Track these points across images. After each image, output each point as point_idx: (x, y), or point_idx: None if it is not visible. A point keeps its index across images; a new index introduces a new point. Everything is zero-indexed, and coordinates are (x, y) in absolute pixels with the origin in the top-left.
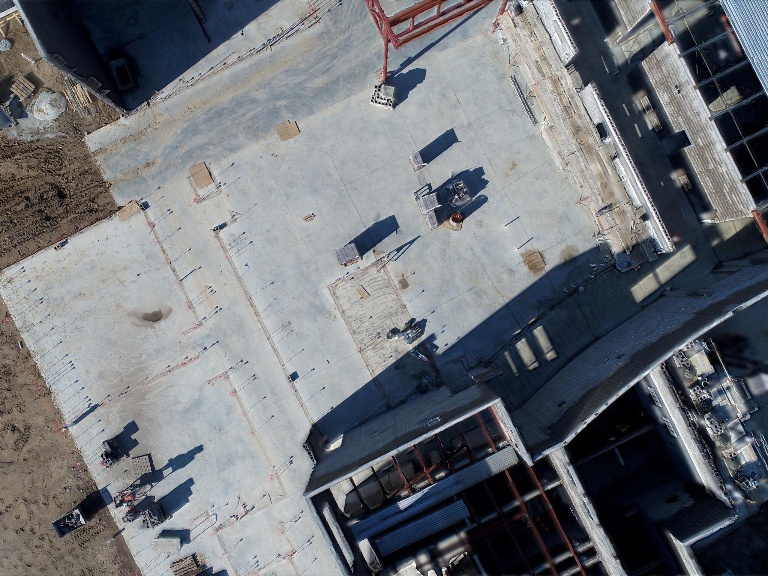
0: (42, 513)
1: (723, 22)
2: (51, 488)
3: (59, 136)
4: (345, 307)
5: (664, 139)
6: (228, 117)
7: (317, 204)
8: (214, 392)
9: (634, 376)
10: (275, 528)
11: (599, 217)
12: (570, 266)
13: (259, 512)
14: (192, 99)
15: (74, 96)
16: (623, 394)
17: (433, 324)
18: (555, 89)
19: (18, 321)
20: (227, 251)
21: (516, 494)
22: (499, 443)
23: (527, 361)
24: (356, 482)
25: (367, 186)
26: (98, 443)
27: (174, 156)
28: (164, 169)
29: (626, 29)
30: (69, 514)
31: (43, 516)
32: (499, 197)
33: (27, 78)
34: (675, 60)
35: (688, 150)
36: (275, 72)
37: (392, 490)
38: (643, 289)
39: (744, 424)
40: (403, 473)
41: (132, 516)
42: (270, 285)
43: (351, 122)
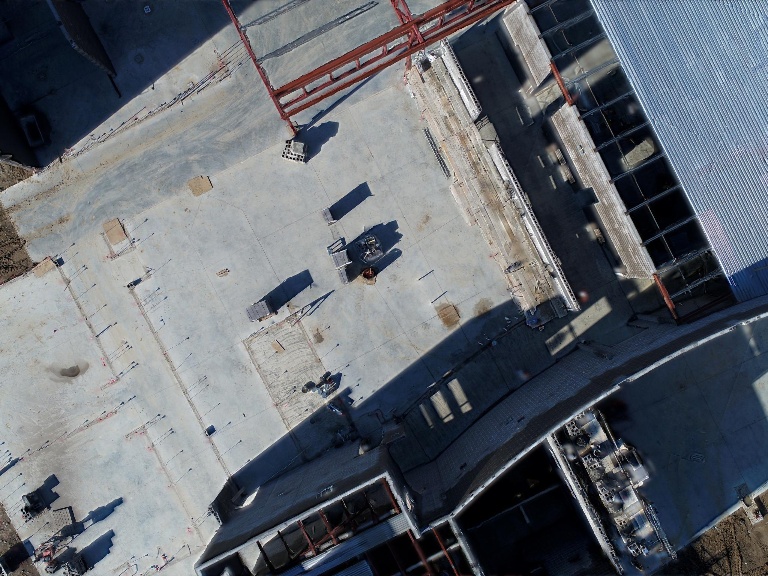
0: None
1: (624, 83)
2: None
3: None
4: (260, 361)
5: (579, 191)
6: (141, 173)
7: (231, 259)
8: (132, 446)
9: (521, 449)
10: None
11: (509, 274)
12: (484, 319)
13: (179, 562)
14: (104, 155)
15: None
16: (536, 446)
17: (348, 378)
18: (464, 145)
19: None
20: (142, 307)
21: (418, 554)
22: None
23: (442, 414)
24: (274, 533)
25: (281, 241)
26: (19, 496)
27: (87, 212)
28: (78, 225)
29: (535, 84)
30: None
31: None
32: (413, 251)
33: None
34: (576, 122)
35: (597, 206)
36: (187, 127)
37: (297, 550)
38: (558, 341)
39: (637, 491)
40: (307, 533)
41: (53, 568)
42: (185, 340)
43: (264, 177)
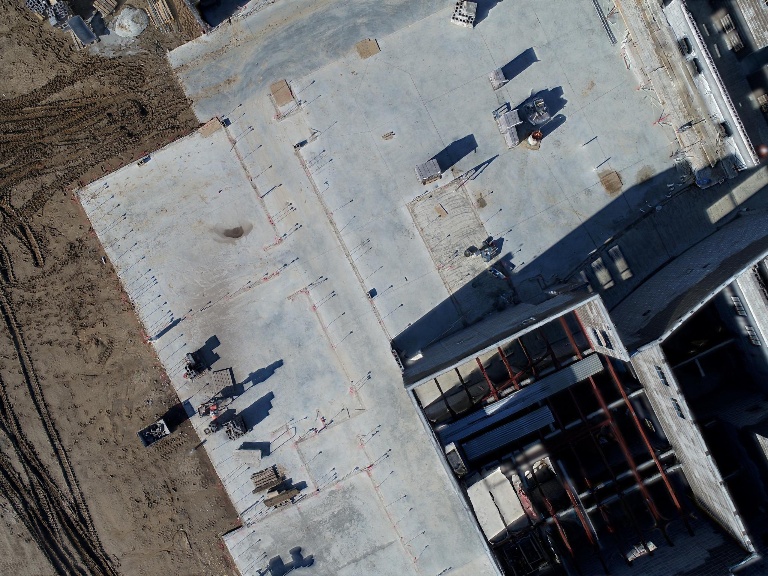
0: (125, 425)
1: None
2: (134, 401)
3: (141, 53)
4: (423, 225)
5: (743, 59)
6: (309, 35)
7: (396, 122)
8: (294, 308)
9: (730, 275)
10: (353, 441)
11: (680, 134)
12: (647, 186)
13: (337, 425)
14: (273, 16)
15: (156, 13)
16: (698, 313)
17: (510, 243)
18: (639, 5)
19: (102, 236)
20: (307, 169)
21: (600, 401)
22: (584, 351)
23: (602, 280)
24: (432, 397)
25: (446, 105)
26: (180, 357)
27: (255, 73)
28: (245, 86)
29: None
30: (153, 425)
31: (126, 428)
32: (577, 117)
33: None
34: None
35: None
36: None
37: (477, 396)
38: (719, 210)
39: None
40: None
41: (215, 427)
42: (349, 203)
43: (431, 40)
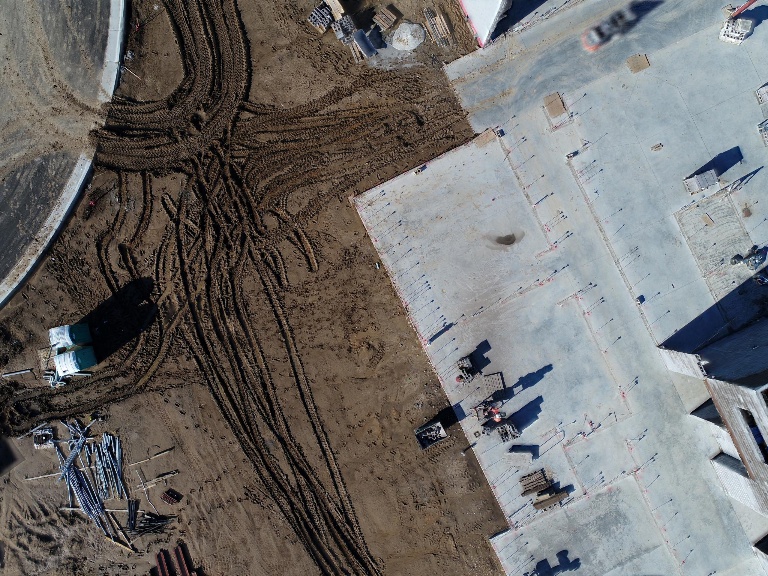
0: (394, 428)
1: None
2: (403, 404)
3: (417, 66)
4: (690, 234)
5: None
6: (581, 49)
7: (665, 134)
8: (564, 313)
9: None
10: (620, 445)
11: None
12: None
13: (605, 430)
14: (547, 32)
15: (433, 27)
16: None
17: None
18: None
19: (377, 242)
20: (578, 178)
21: None
22: None
23: None
24: (698, 402)
25: (713, 118)
26: (452, 361)
27: (529, 86)
28: (519, 99)
29: None
30: None
31: (395, 431)
32: None
33: (388, 10)
34: None
35: None
36: (626, 7)
37: None
38: None
39: None
40: None
41: None
42: (619, 211)
43: (699, 56)
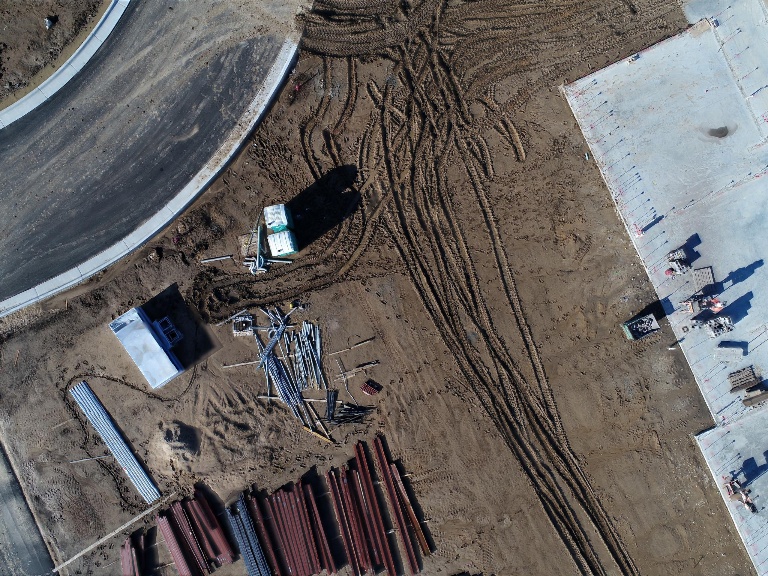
0: (599, 322)
1: None
2: (609, 298)
3: None
4: None
5: None
6: None
7: None
8: None
9: None
10: None
11: None
12: None
13: None
14: None
15: None
16: None
17: None
18: None
19: (588, 132)
20: None
21: None
22: None
23: None
24: None
25: None
26: (661, 254)
27: None
28: None
29: None
30: None
31: (599, 325)
32: None
33: None
34: None
35: None
36: None
37: None
38: None
39: None
40: None
41: None
42: None
43: None
